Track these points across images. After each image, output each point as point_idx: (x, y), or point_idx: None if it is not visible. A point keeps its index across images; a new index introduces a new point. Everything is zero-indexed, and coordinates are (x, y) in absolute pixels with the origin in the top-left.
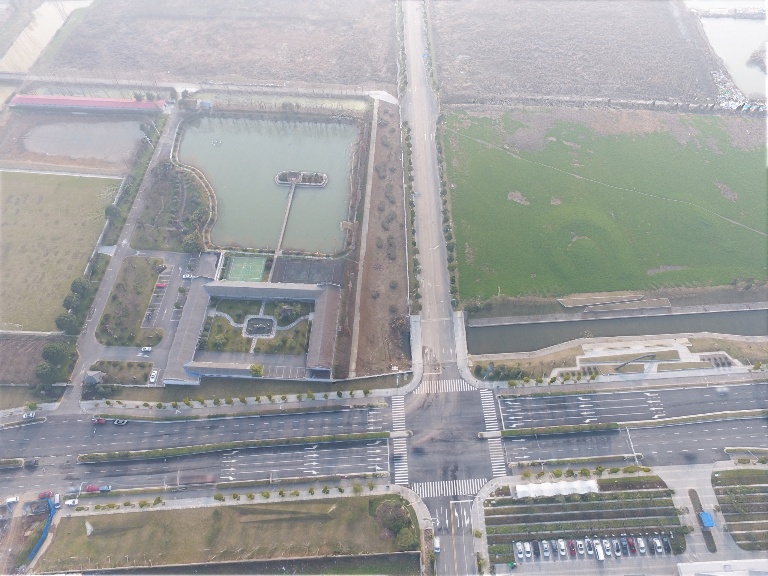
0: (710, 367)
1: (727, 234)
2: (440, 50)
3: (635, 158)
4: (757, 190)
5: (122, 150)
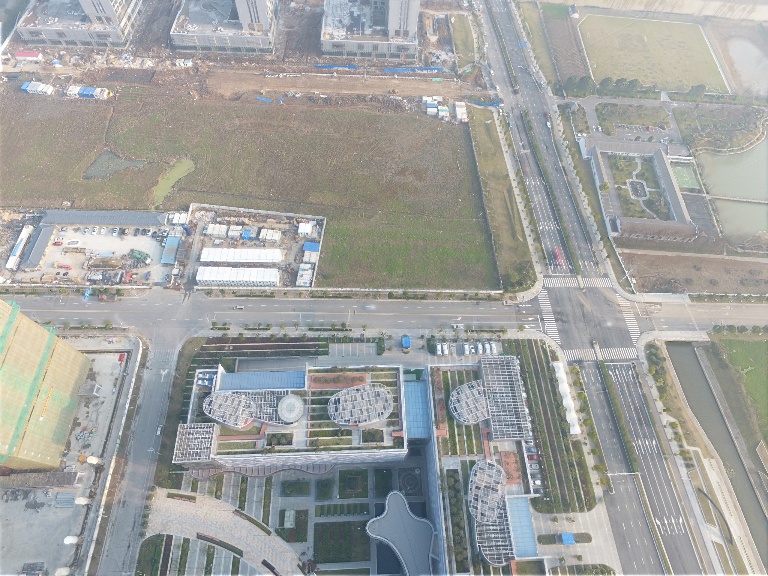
0: None
1: None
2: None
3: None
4: None
5: None
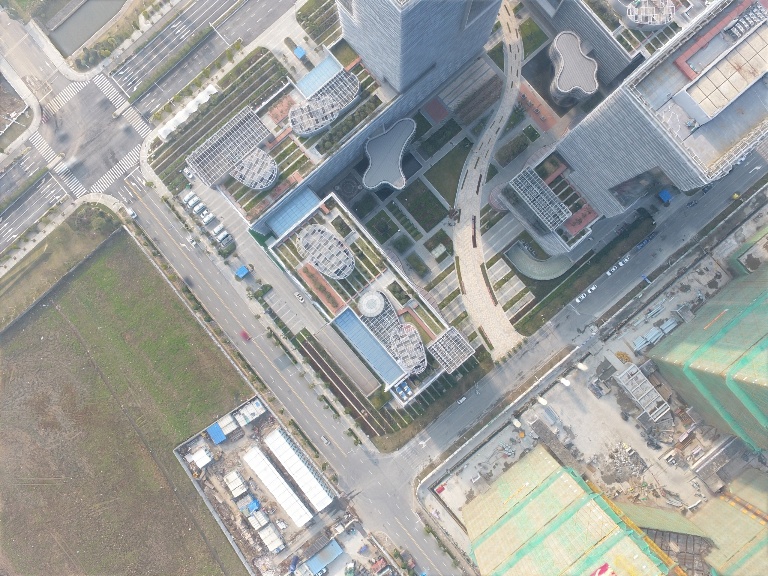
0: None
1: None
2: None
3: None
4: None
5: None
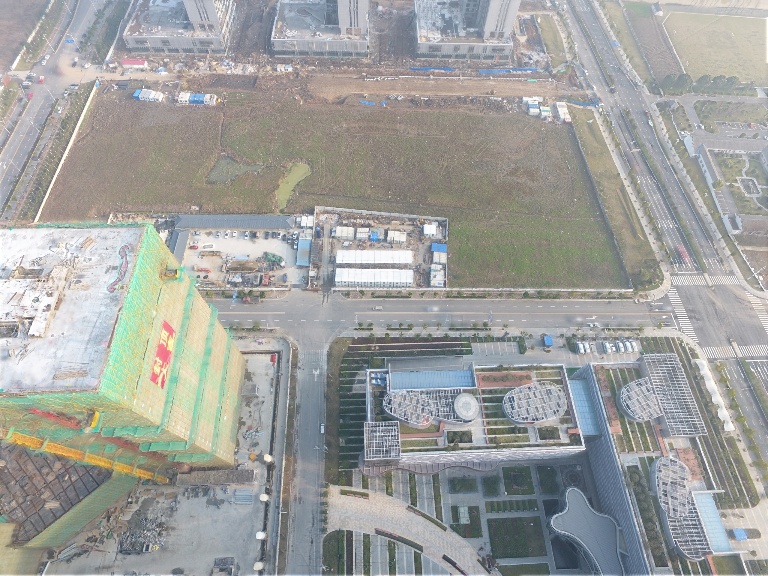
0: None
1: None
2: None
3: None
4: None
5: None
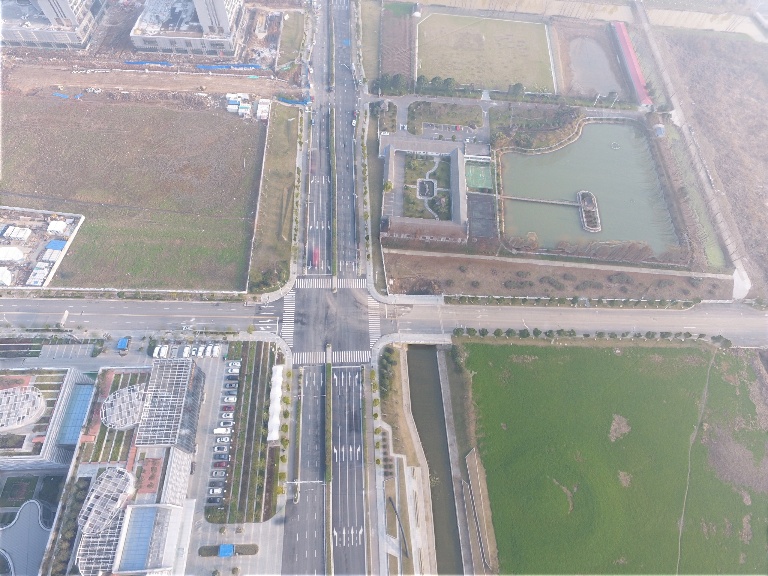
0: None
1: None
2: None
3: None
4: None
5: (583, 86)
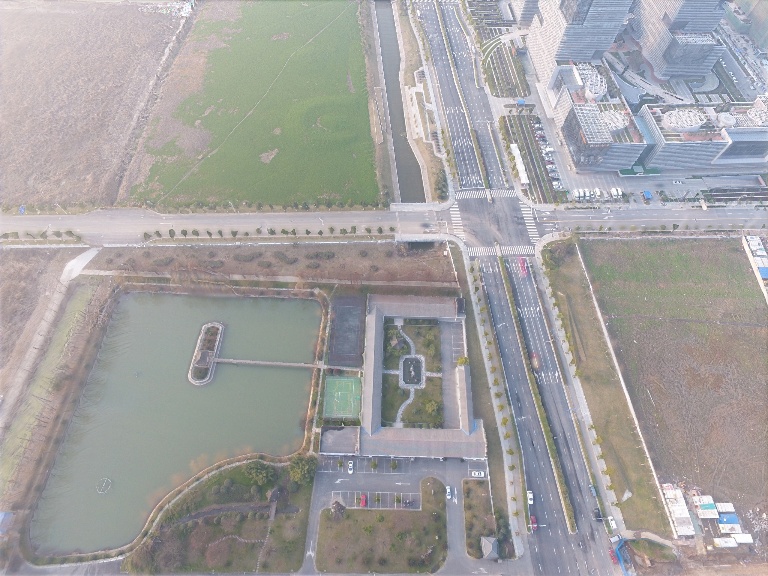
0: (426, 80)
1: (321, 46)
2: (7, 201)
3: (236, 75)
4: (282, 22)
5: None
